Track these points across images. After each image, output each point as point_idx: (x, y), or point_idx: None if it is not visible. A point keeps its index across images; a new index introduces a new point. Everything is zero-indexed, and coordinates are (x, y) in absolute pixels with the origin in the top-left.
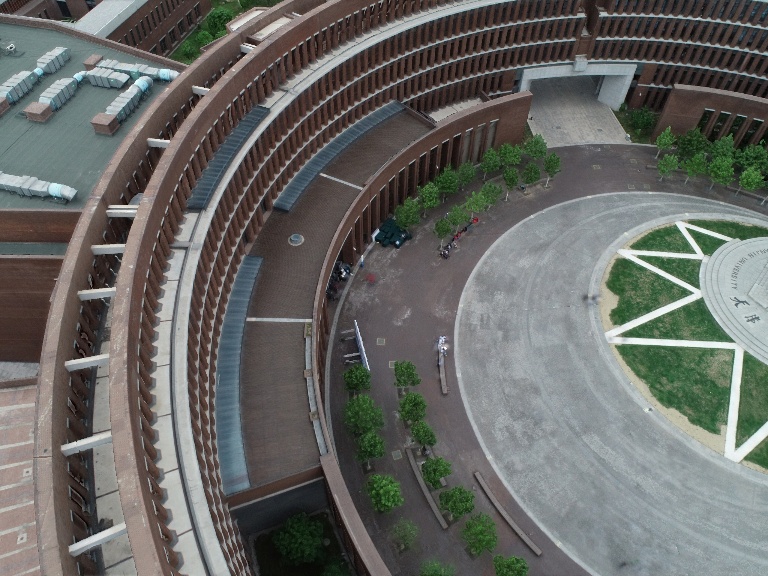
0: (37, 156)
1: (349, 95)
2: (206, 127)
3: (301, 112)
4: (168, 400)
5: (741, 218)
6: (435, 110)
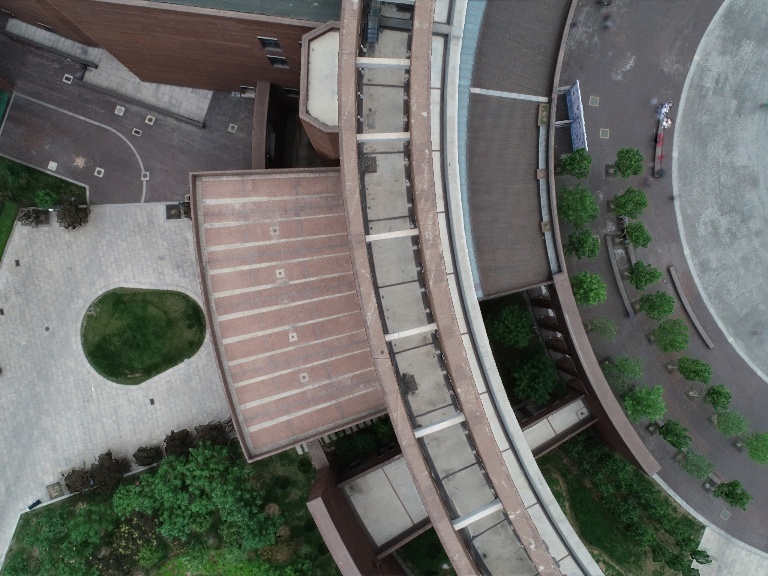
0: None
1: None
2: None
3: None
4: (449, 257)
5: None
6: None
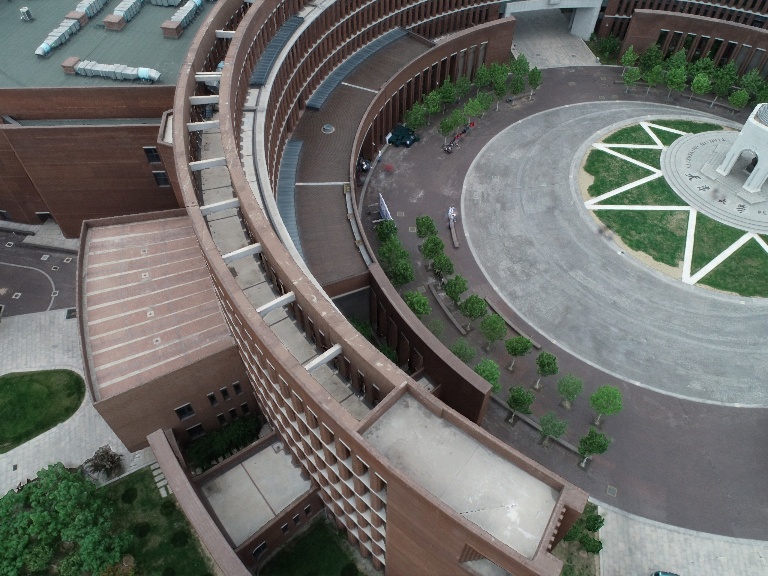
0: (119, 54)
1: (363, 17)
2: (260, 23)
3: (326, 26)
4: (260, 201)
5: (694, 118)
6: (432, 39)
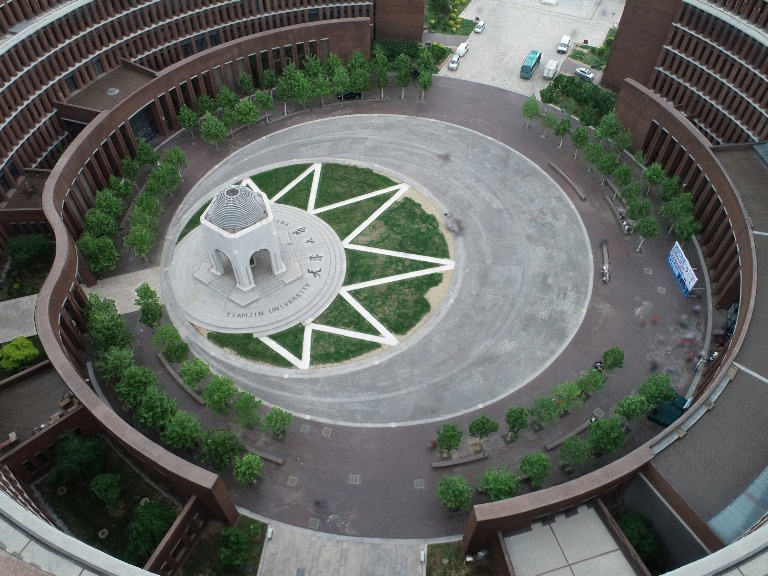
0: None
1: None
2: None
3: None
4: None
5: (228, 359)
6: None
